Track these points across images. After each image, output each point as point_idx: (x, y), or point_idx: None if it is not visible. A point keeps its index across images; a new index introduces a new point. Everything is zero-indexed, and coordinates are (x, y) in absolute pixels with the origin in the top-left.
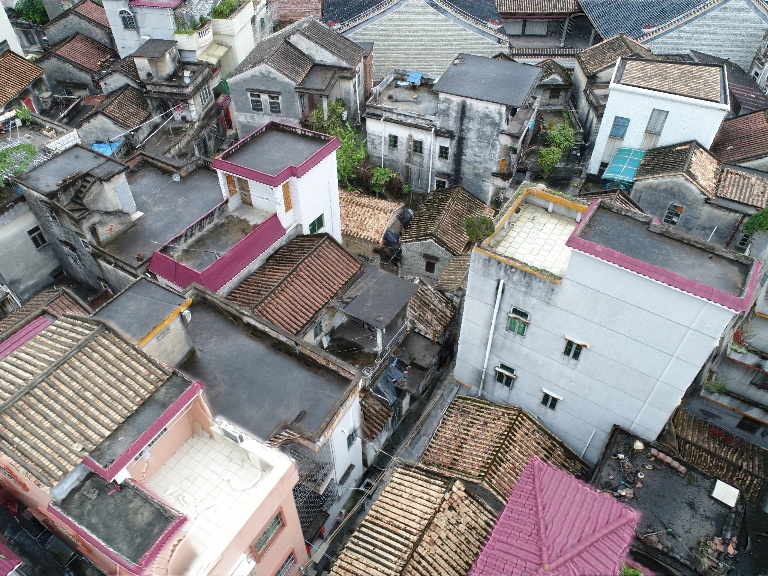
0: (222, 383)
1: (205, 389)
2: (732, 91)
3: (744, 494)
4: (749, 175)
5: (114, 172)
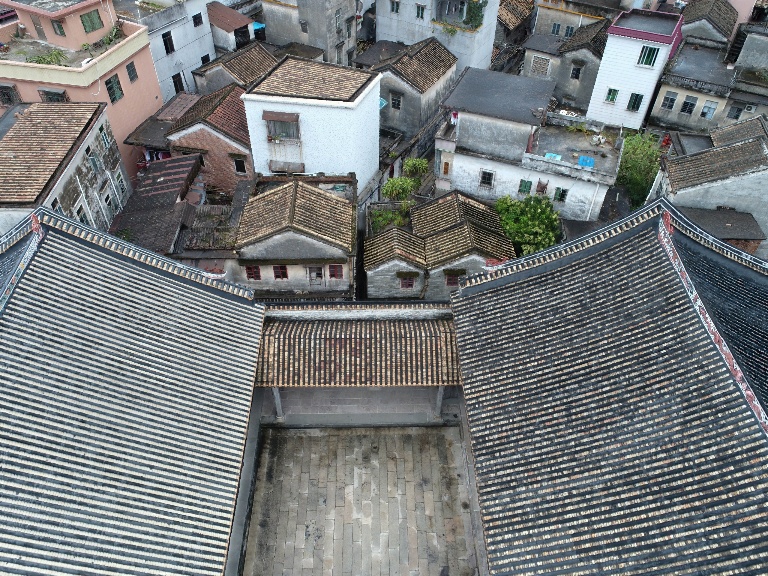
0: (599, 4)
1: (604, 3)
2: (188, 173)
3: (363, 38)
4: None
5: (748, 26)
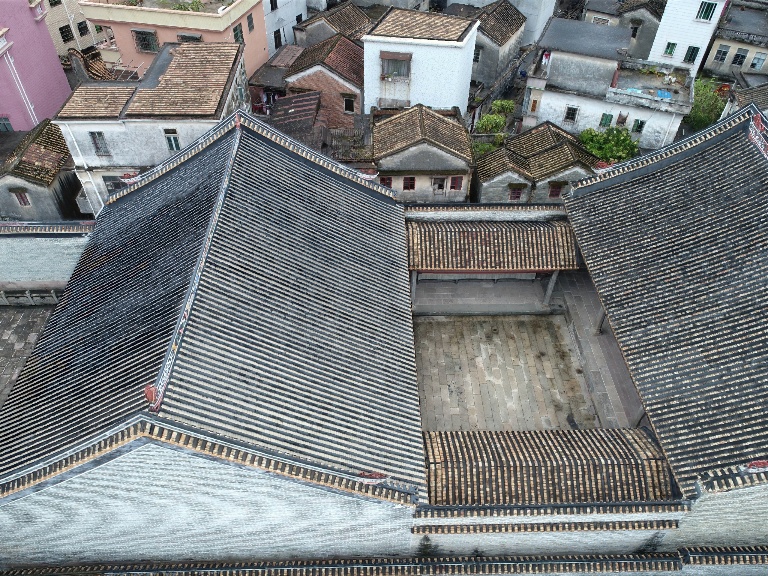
0: None
1: None
2: None
3: None
4: None
5: None
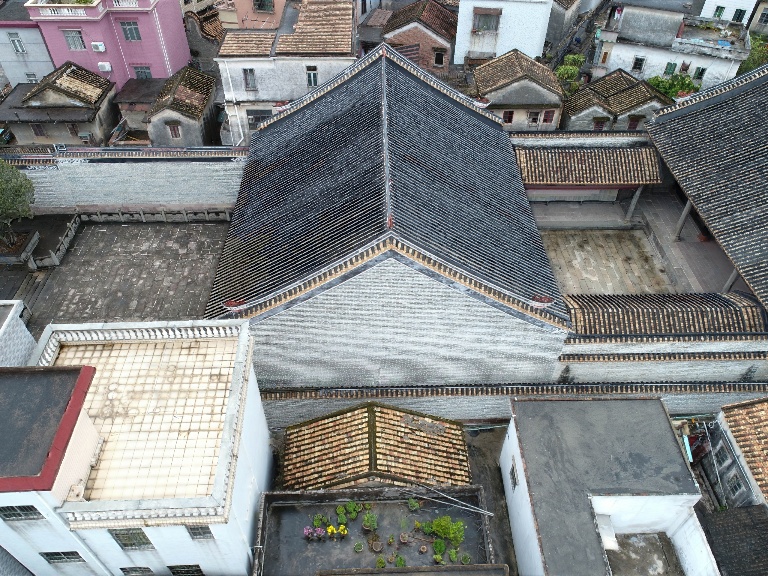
0: None
1: None
2: None
3: None
4: (450, 3)
5: None
